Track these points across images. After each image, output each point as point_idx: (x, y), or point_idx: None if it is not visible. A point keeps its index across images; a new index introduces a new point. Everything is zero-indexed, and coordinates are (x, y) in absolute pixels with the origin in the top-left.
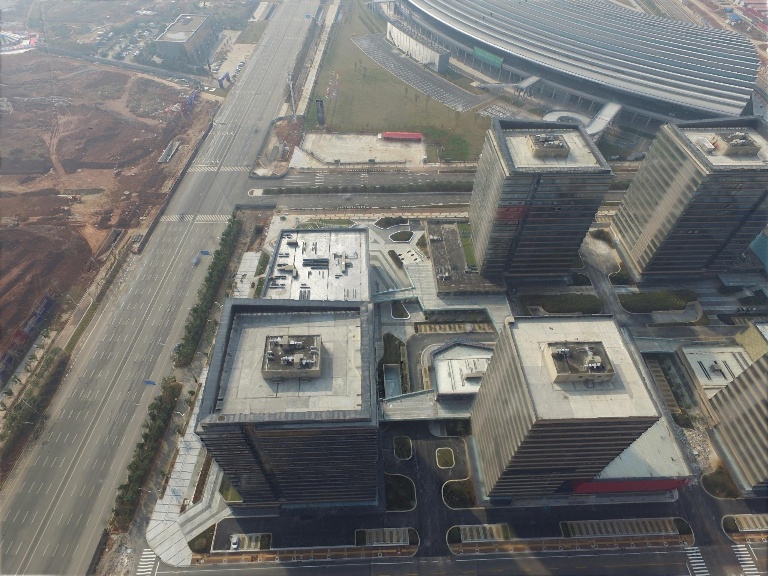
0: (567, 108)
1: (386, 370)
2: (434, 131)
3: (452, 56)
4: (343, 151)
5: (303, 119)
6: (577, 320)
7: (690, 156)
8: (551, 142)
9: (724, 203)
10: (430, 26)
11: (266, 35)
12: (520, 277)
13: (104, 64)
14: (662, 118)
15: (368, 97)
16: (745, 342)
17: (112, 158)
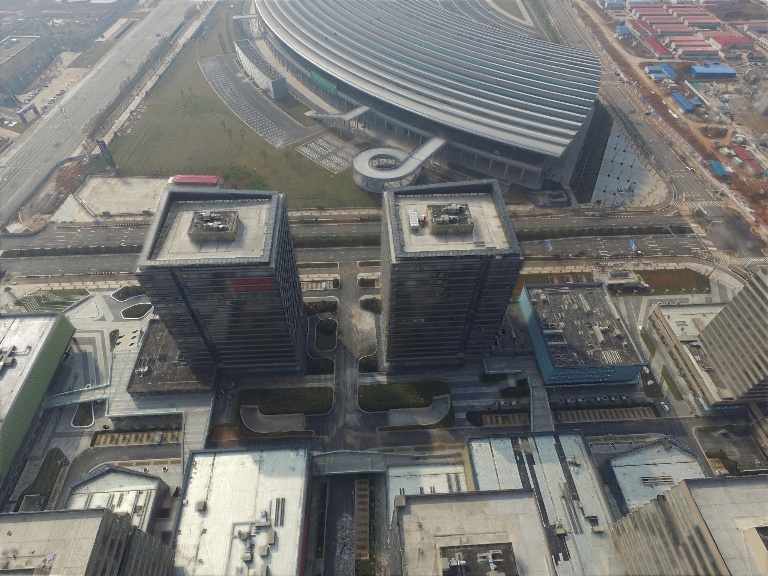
0: (400, 141)
1: (30, 501)
2: (237, 172)
3: (299, 80)
4: (122, 199)
5: (95, 160)
6: (56, 517)
7: (387, 237)
8: (210, 223)
9: (436, 292)
10: (279, 46)
11: (106, 57)
12: (241, 368)
13: None
14: (487, 156)
15: (182, 131)
16: (464, 461)
17: None
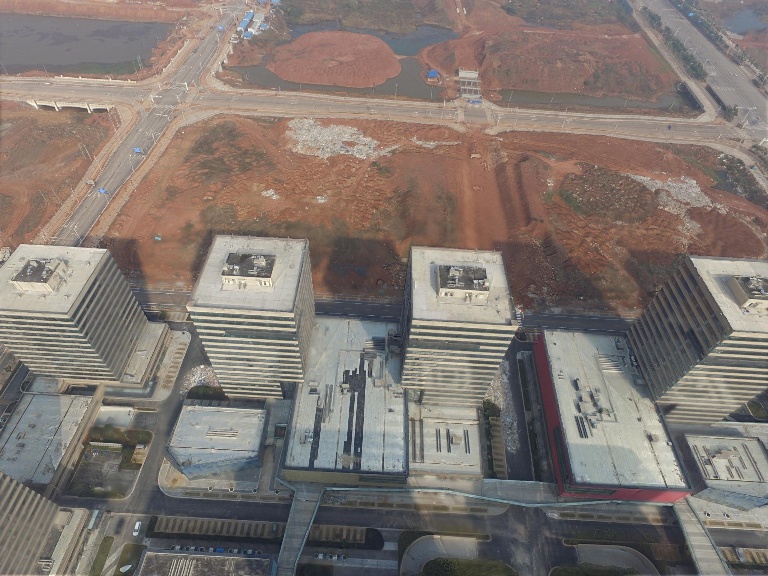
0: None
1: None
2: None
3: None
4: None
5: None
6: None
7: None
8: None
9: None
10: None
11: None
12: None
13: None
14: None
15: None
16: None
17: None
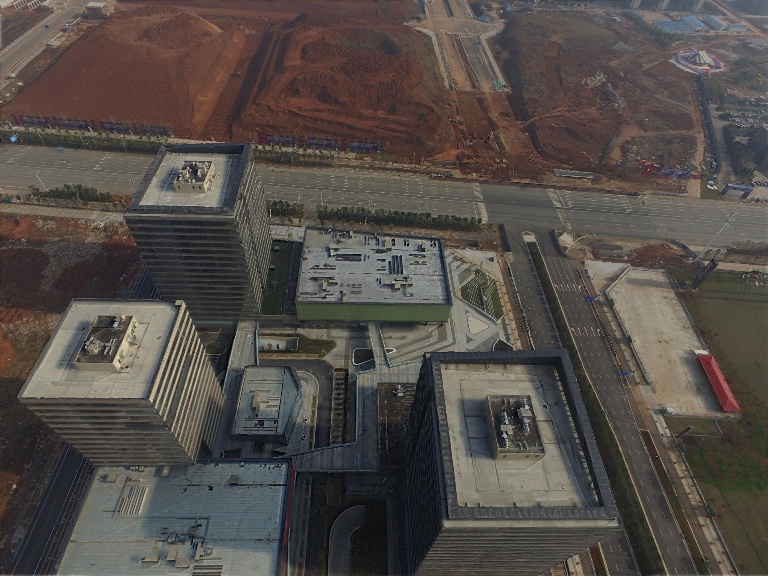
0: None
1: None
2: (766, 437)
3: None
4: (642, 310)
5: (695, 267)
6: None
7: None
8: None
9: None
10: None
11: None
12: None
13: (703, 112)
14: None
15: None
16: None
17: (546, 144)
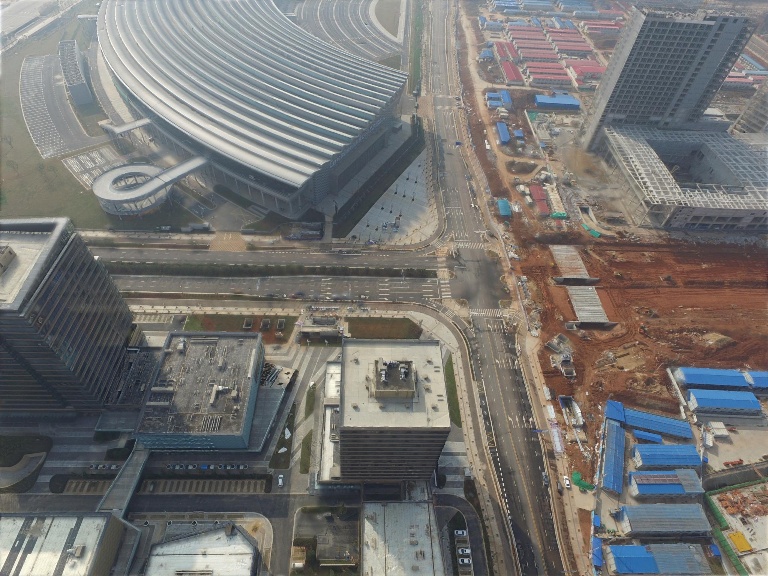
0: (180, 158)
1: None
2: None
3: None
4: None
5: None
6: None
7: None
8: None
9: None
10: None
11: None
12: None
13: None
14: (243, 181)
15: None
16: None
17: None
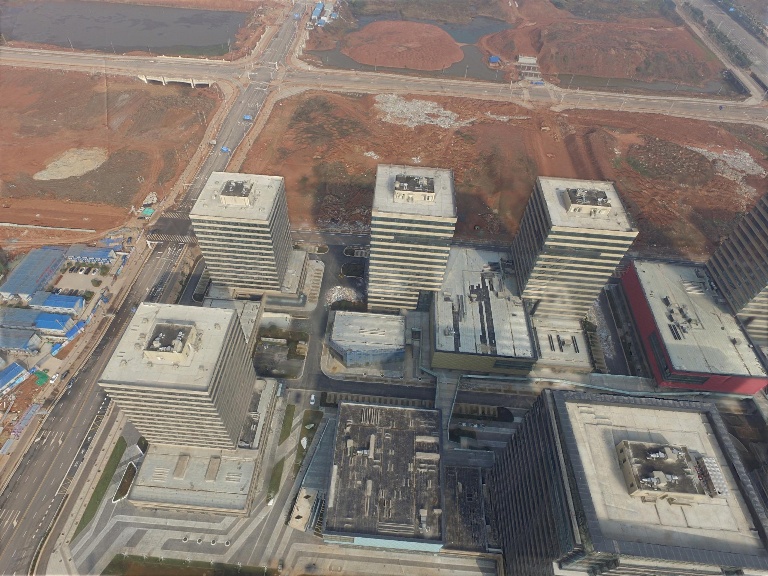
0: None
1: None
2: None
3: None
4: None
5: None
6: None
7: None
8: None
9: None
10: None
11: None
12: None
13: None
14: None
15: None
16: None
17: None
